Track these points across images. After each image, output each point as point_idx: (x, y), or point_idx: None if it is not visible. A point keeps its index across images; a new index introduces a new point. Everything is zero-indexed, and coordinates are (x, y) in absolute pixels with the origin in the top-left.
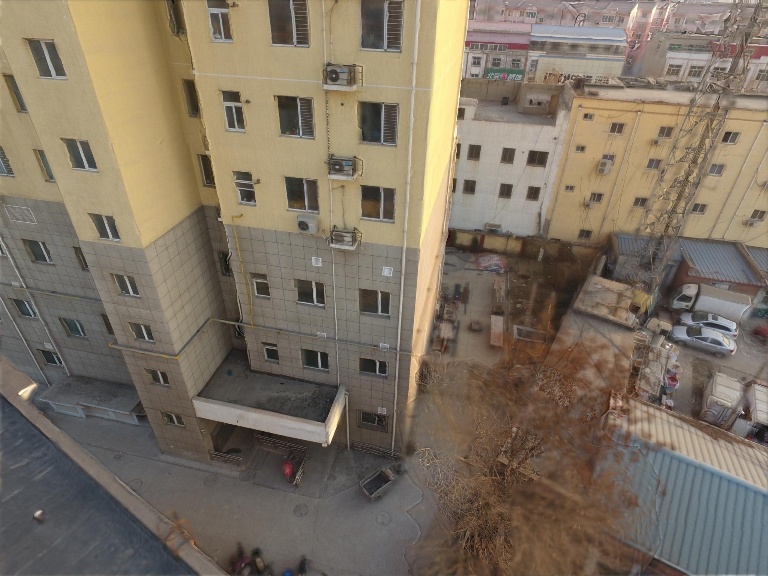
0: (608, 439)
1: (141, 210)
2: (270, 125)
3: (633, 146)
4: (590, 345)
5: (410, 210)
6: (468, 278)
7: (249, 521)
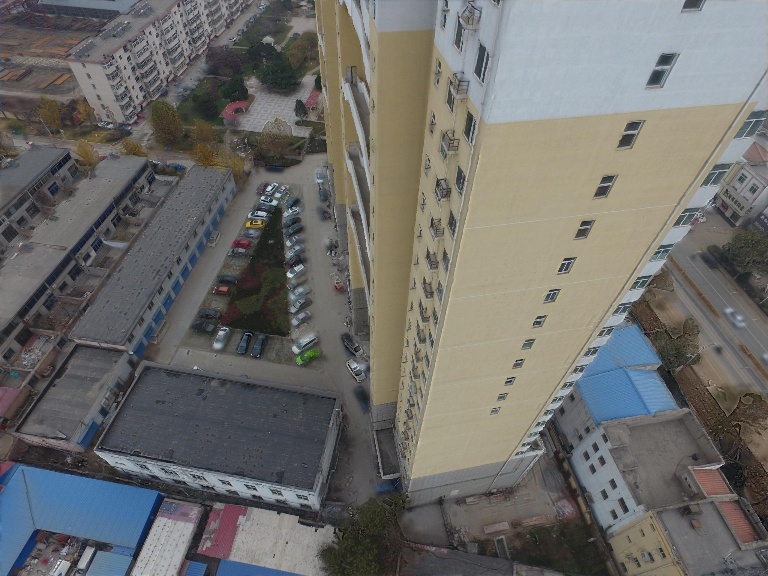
0: (392, 564)
1: (377, 400)
2: (402, 420)
3: (659, 570)
4: (488, 575)
5: (409, 471)
6: (540, 498)
7: (362, 468)
